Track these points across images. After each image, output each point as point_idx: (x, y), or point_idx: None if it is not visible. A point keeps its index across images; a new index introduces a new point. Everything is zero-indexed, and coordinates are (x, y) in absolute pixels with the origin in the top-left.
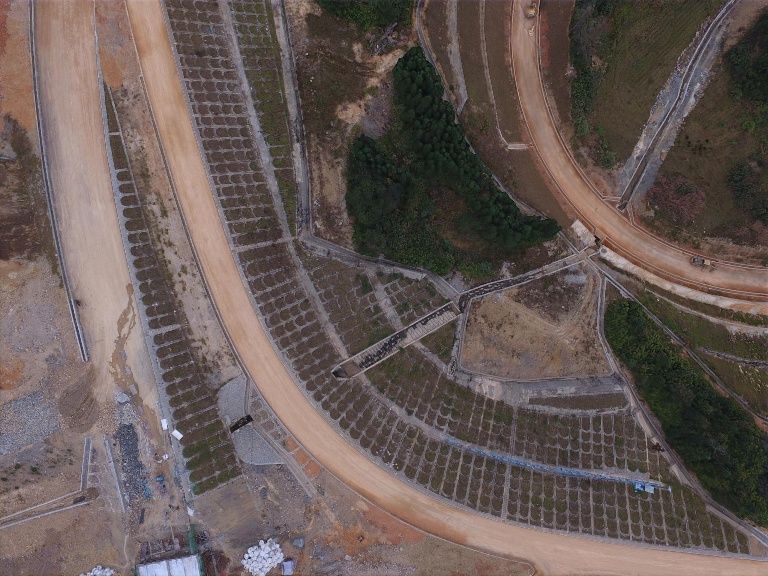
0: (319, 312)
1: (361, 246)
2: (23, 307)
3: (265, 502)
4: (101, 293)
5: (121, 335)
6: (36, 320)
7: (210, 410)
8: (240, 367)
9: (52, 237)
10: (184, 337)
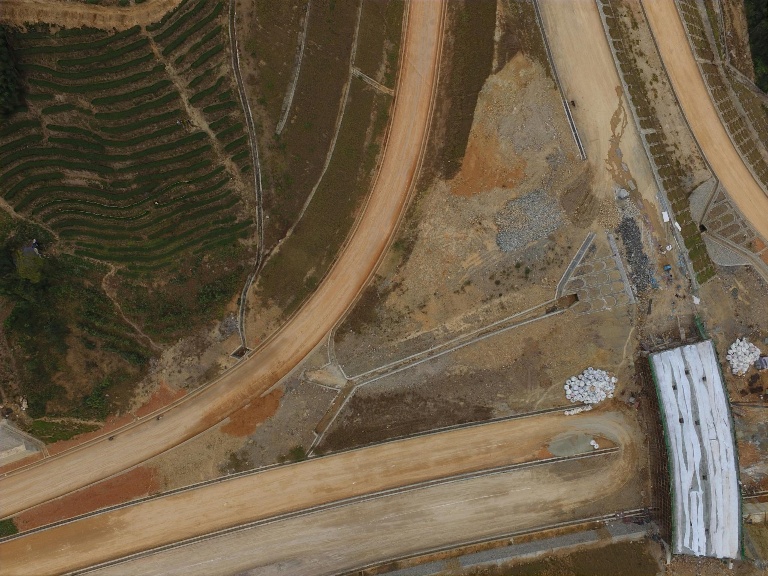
0: (750, 131)
1: (761, 79)
2: (525, 106)
3: (737, 302)
4: (592, 95)
5: (615, 134)
6: (537, 119)
7: (687, 211)
8: (710, 171)
9: (542, 43)
10: (659, 141)
